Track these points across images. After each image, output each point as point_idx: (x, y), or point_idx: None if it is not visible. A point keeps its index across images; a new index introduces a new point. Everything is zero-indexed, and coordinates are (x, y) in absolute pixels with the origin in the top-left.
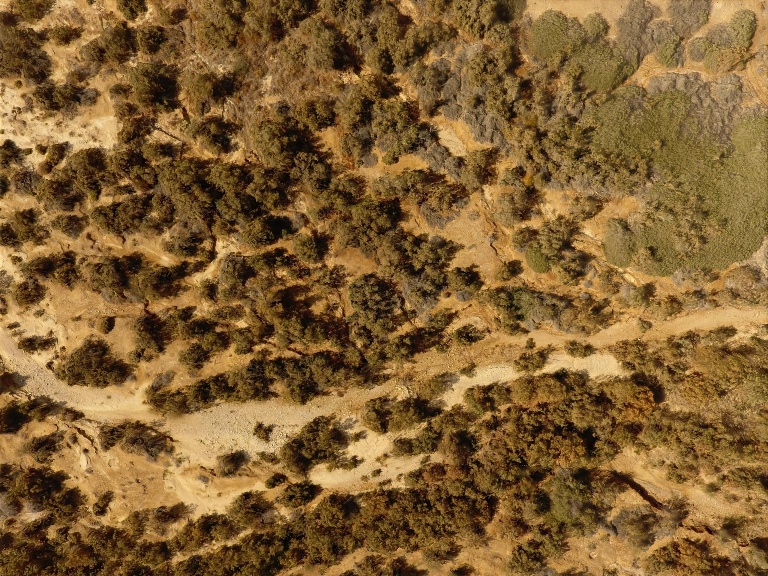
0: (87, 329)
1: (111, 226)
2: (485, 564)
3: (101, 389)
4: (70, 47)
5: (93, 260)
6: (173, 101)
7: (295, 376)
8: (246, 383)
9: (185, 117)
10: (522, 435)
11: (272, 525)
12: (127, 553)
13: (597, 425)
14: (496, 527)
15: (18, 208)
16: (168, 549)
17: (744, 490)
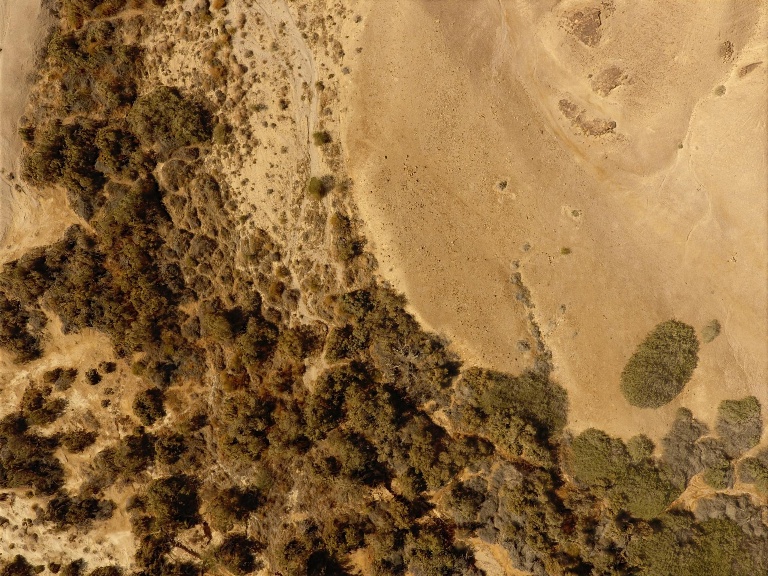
0: None
1: None
2: None
3: None
4: (84, 454)
5: None
6: (193, 517)
7: None
8: None
9: (206, 532)
10: None
11: None
12: None
13: None
14: None
15: None
16: None
17: None
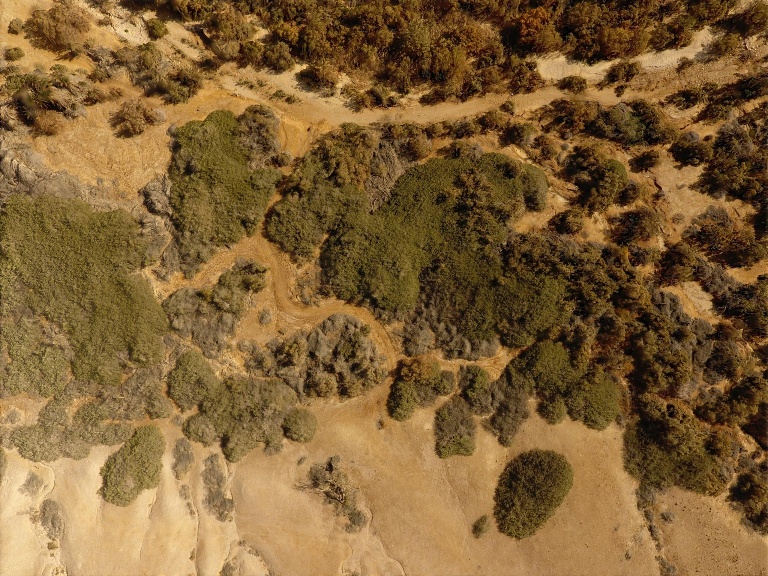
0: None
1: None
2: None
3: None
4: None
5: None
6: None
7: None
8: None
9: None
10: None
11: None
12: None
13: (568, 7)
14: None
15: None
16: None
17: None
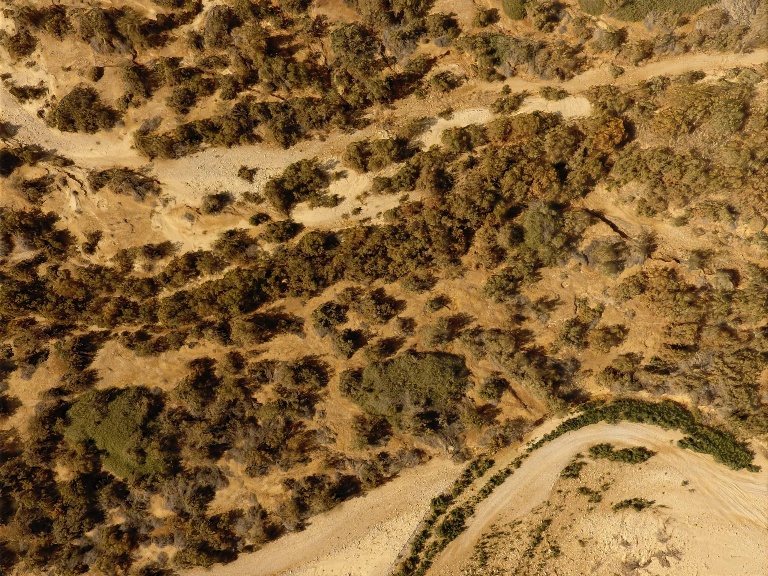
0: (77, 78)
1: None
2: (461, 293)
3: (90, 134)
4: None
5: (83, 12)
6: None
7: (278, 116)
8: (230, 119)
9: None
10: (497, 165)
11: (255, 260)
12: (115, 288)
13: (569, 158)
14: (471, 258)
15: None
16: (155, 284)
17: (711, 223)
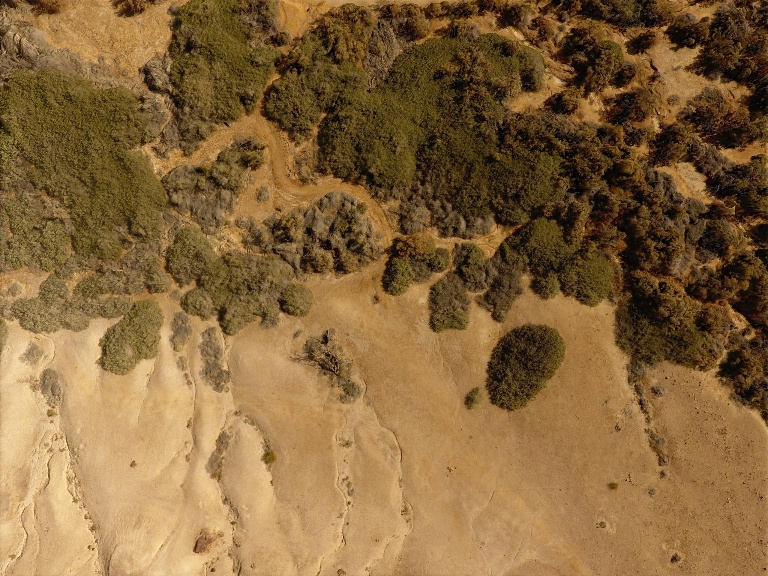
0: None
1: None
2: None
3: None
4: None
5: None
6: None
7: None
8: None
9: None
10: None
11: None
12: None
13: None
14: None
15: None
16: None
17: None
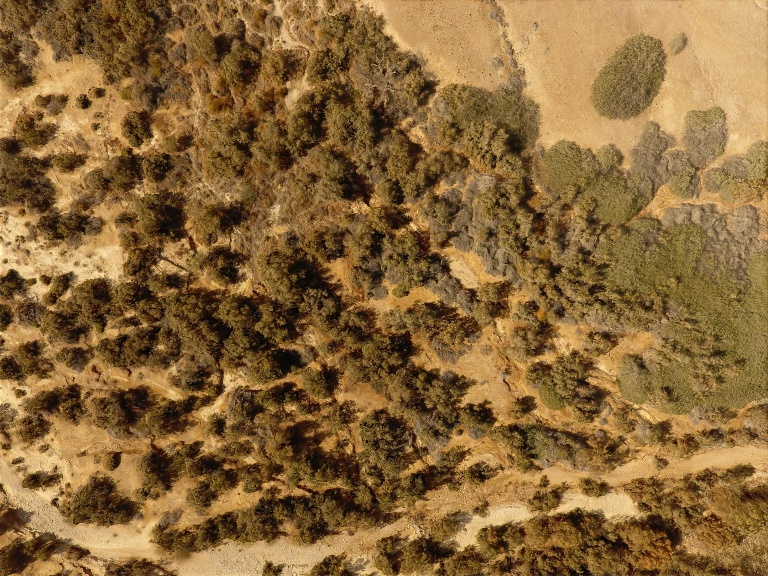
0: (93, 465)
1: (117, 362)
2: None
3: (107, 527)
4: (74, 174)
5: (98, 394)
6: (179, 231)
7: (305, 517)
8: (255, 527)
9: (192, 246)
10: None
11: None
12: None
13: None
14: None
15: (22, 340)
16: None
17: None
